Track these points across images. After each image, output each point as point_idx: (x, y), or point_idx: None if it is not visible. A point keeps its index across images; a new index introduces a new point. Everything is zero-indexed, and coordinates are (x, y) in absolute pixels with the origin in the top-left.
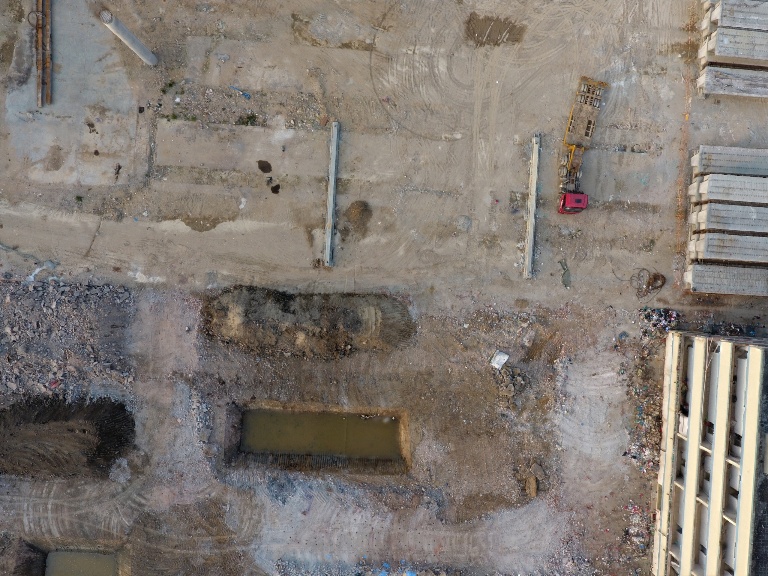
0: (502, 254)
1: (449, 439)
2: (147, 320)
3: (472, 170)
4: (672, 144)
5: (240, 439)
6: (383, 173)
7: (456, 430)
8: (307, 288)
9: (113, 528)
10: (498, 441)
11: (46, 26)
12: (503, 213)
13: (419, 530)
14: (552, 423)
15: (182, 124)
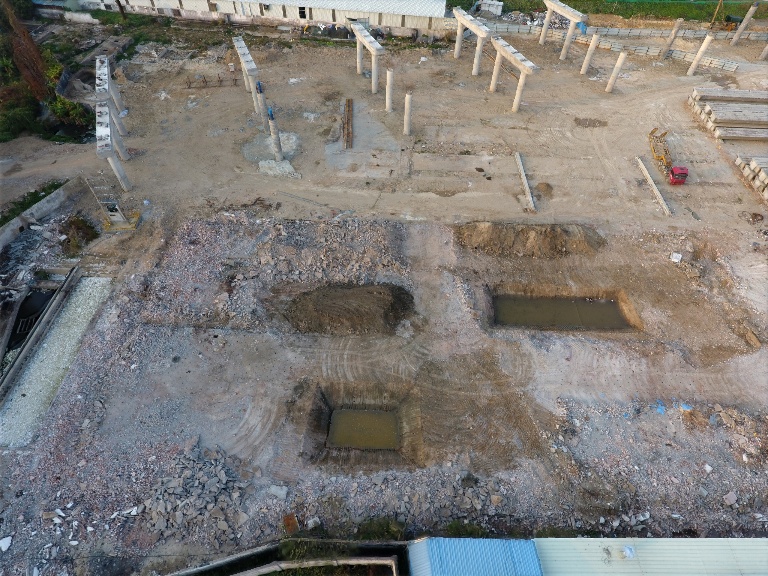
0: (645, 205)
1: (665, 307)
2: (416, 238)
3: (606, 170)
4: (719, 160)
5: (494, 315)
6: (552, 172)
7: (667, 302)
8: (523, 222)
9: (402, 373)
10: (705, 308)
11: (349, 123)
12: (635, 187)
13: (675, 372)
14: (740, 296)
15: (427, 155)
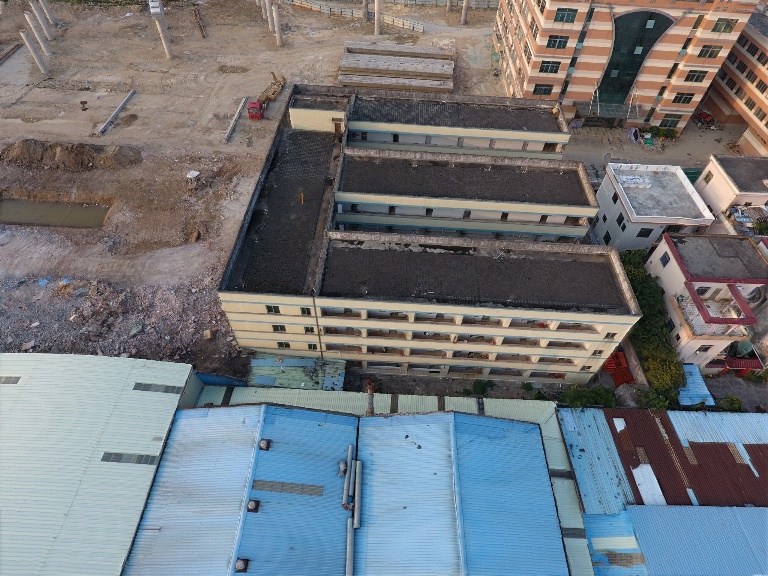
0: (212, 135)
1: (141, 211)
2: None
3: (205, 106)
4: None
5: None
6: (152, 106)
7: (148, 207)
8: None
9: None
10: (177, 213)
11: None
12: (217, 120)
13: (90, 258)
14: (221, 205)
15: None
